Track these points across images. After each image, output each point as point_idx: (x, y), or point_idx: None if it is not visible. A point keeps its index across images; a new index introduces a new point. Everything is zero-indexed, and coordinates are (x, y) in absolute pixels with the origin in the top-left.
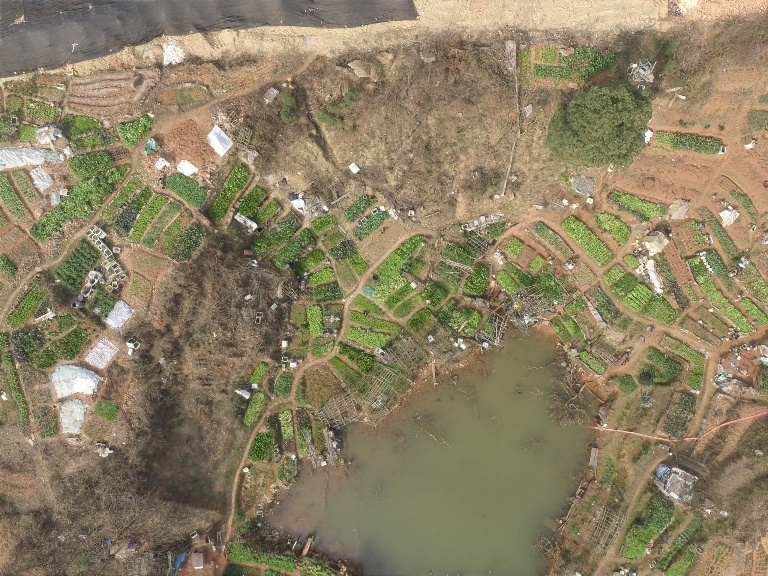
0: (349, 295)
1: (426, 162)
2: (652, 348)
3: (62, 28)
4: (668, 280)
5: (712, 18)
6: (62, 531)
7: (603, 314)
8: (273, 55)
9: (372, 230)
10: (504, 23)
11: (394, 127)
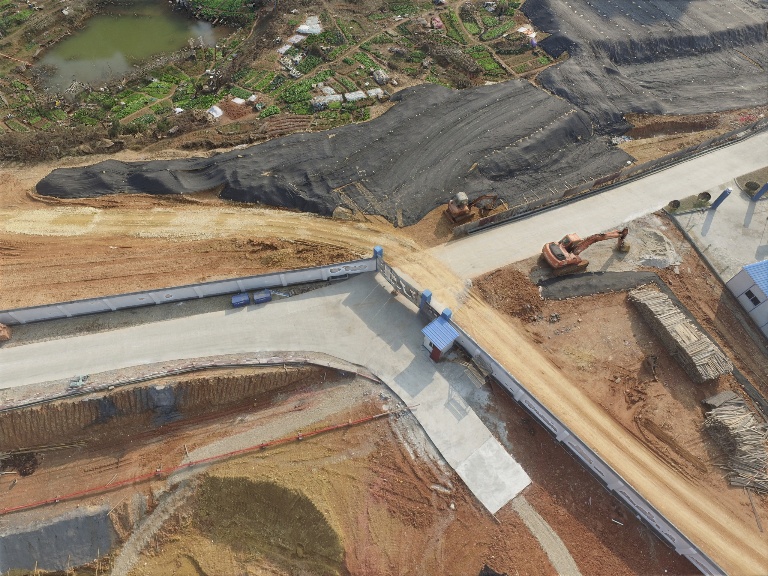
0: None
1: None
2: None
3: None
4: None
5: None
6: None
7: None
8: None
9: None
10: None
11: None
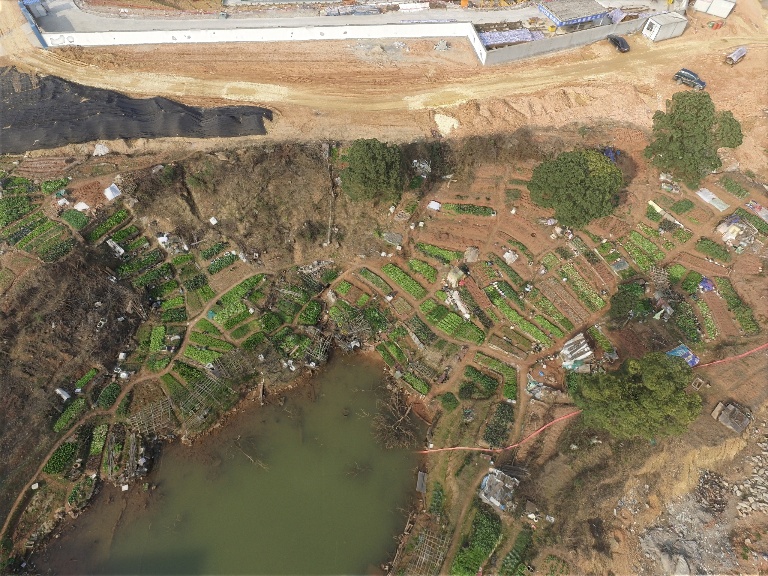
0: (194, 319)
1: (267, 215)
2: (469, 366)
3: (32, 131)
4: (471, 305)
5: (461, 137)
6: None
7: (420, 337)
8: (167, 151)
9: (222, 267)
10: (323, 137)
11: None
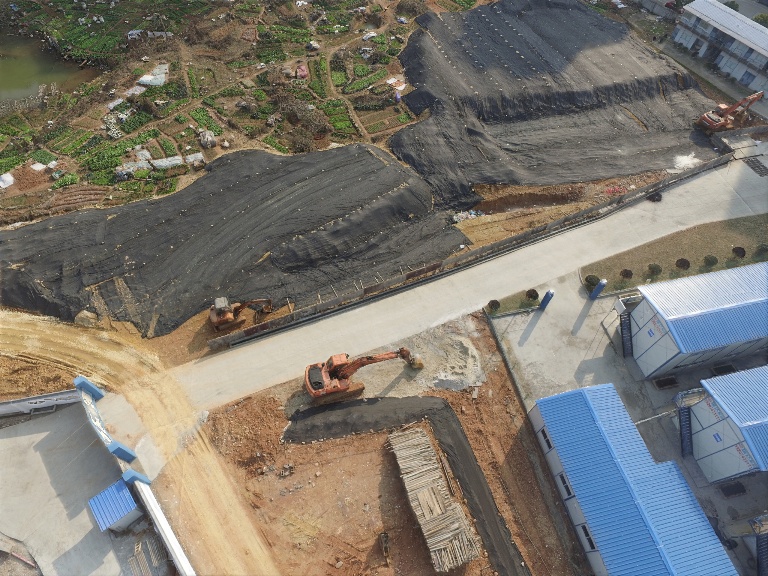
0: None
1: None
2: None
3: None
4: None
5: None
6: (186, 40)
7: None
8: None
9: None
10: None
11: None
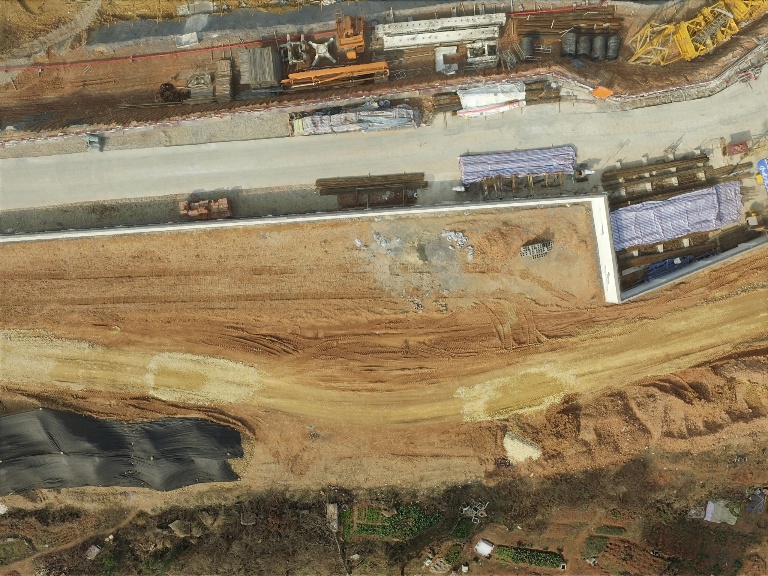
0: None
1: None
2: None
3: None
4: None
5: (540, 475)
6: None
7: None
8: (95, 511)
9: None
10: (327, 483)
11: (224, 564)
